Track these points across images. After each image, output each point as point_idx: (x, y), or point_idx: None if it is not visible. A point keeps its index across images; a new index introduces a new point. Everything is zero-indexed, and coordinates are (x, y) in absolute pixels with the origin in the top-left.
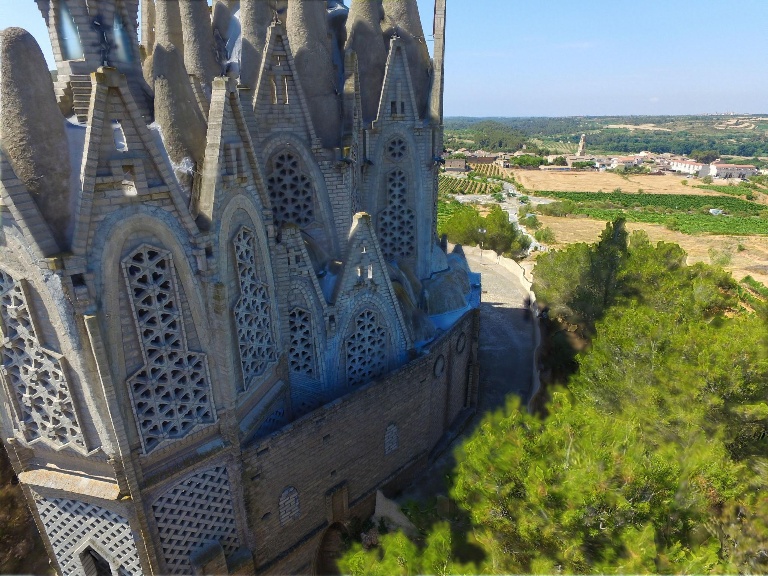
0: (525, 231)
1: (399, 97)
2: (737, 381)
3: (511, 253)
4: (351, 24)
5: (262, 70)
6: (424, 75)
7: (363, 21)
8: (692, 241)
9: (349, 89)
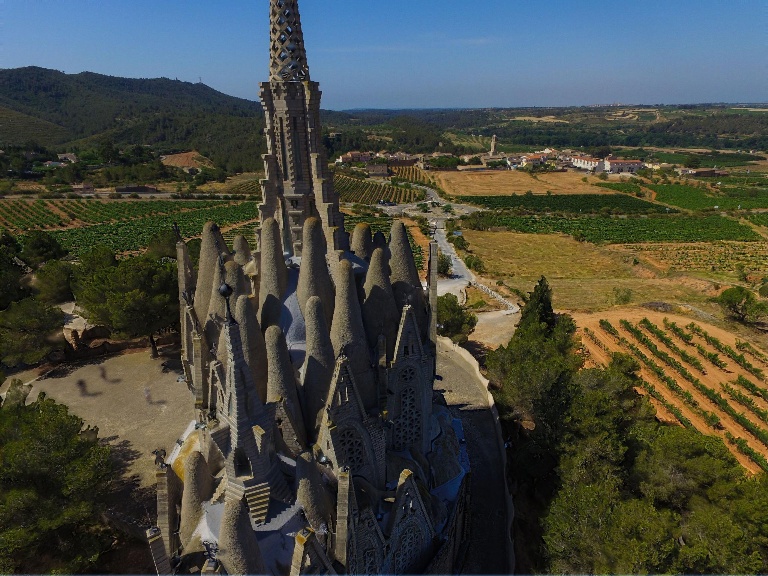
0: (455, 252)
1: (410, 344)
2: (655, 562)
3: (462, 334)
4: (369, 289)
5: (334, 392)
6: (423, 313)
7: (380, 289)
8: (597, 253)
9: (383, 365)
